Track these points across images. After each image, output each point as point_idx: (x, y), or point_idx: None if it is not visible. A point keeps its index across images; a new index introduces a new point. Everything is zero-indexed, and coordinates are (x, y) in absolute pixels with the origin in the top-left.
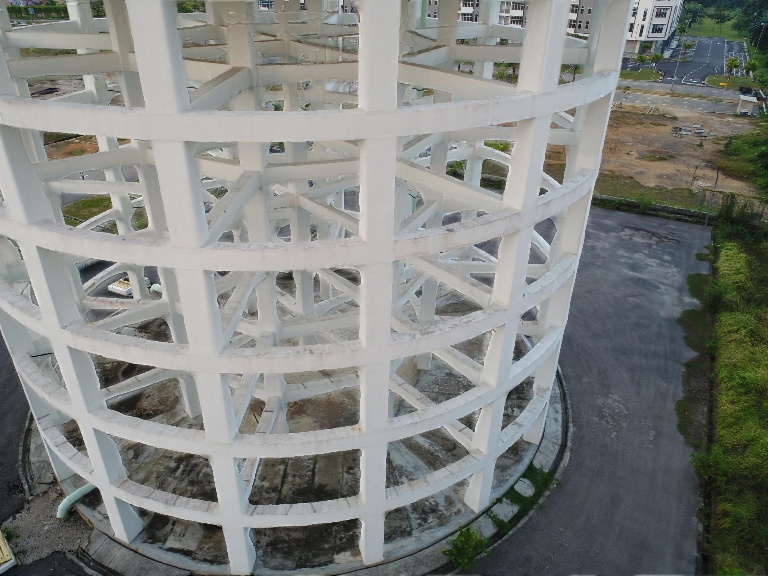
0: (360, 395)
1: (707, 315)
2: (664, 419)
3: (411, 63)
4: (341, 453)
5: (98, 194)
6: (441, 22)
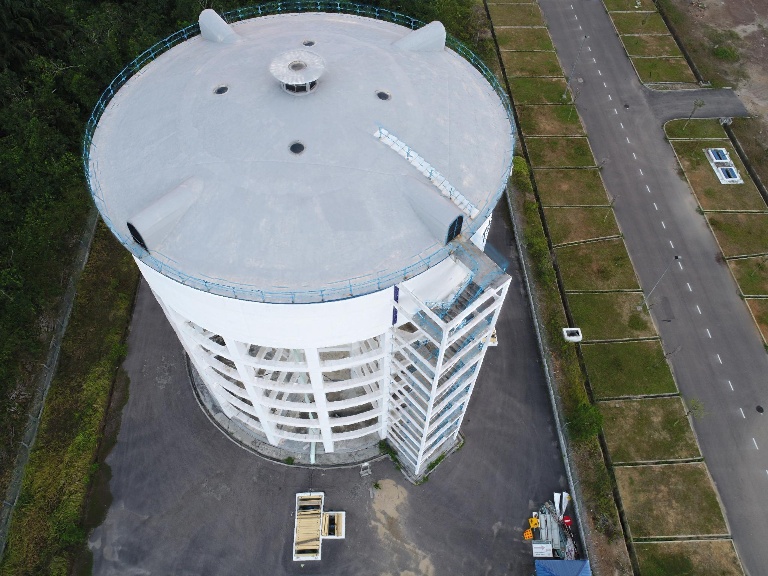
0: None
1: (87, 519)
2: (136, 384)
3: None
4: None
5: (697, 447)
6: None
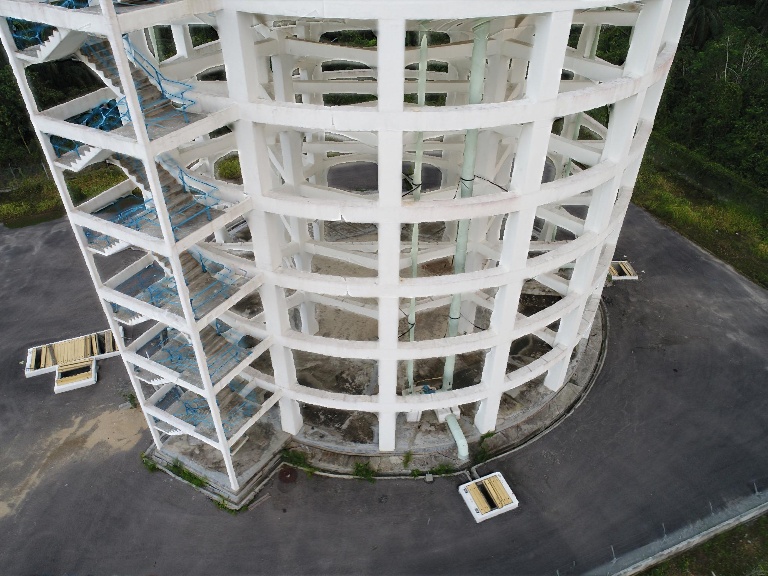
0: None
1: None
2: None
3: None
4: (422, 229)
5: None
6: None
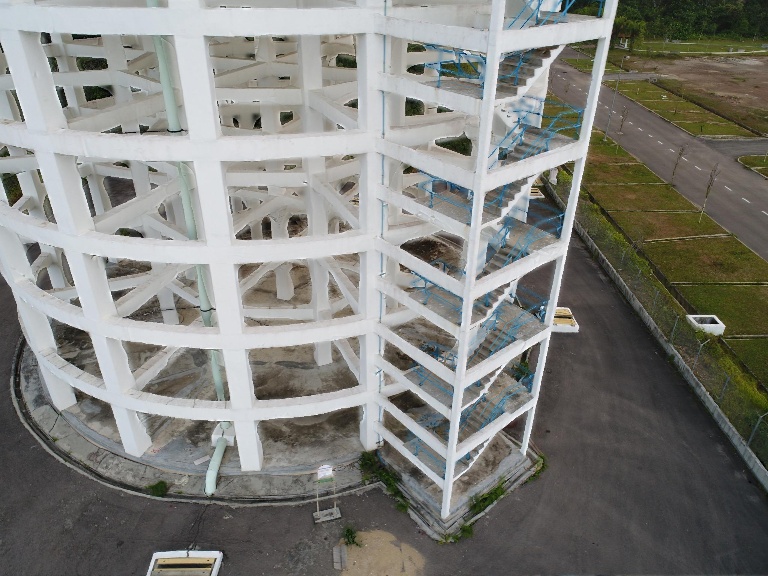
0: None
1: None
2: None
3: None
4: None
5: None
6: (118, 14)
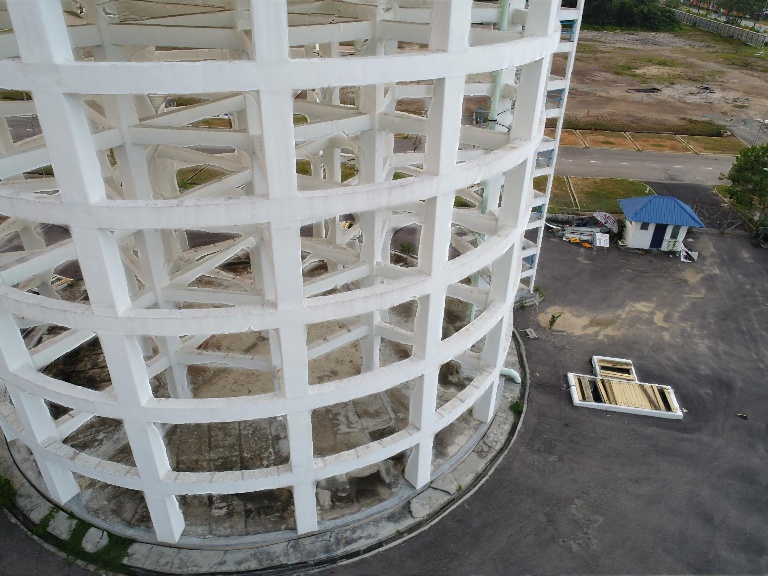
0: (220, 379)
1: None
2: None
3: (78, 25)
4: None
5: None
6: None
